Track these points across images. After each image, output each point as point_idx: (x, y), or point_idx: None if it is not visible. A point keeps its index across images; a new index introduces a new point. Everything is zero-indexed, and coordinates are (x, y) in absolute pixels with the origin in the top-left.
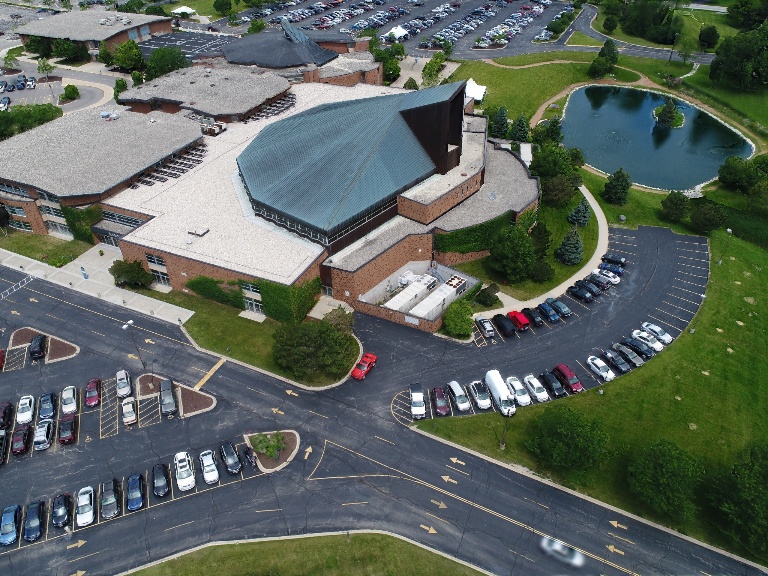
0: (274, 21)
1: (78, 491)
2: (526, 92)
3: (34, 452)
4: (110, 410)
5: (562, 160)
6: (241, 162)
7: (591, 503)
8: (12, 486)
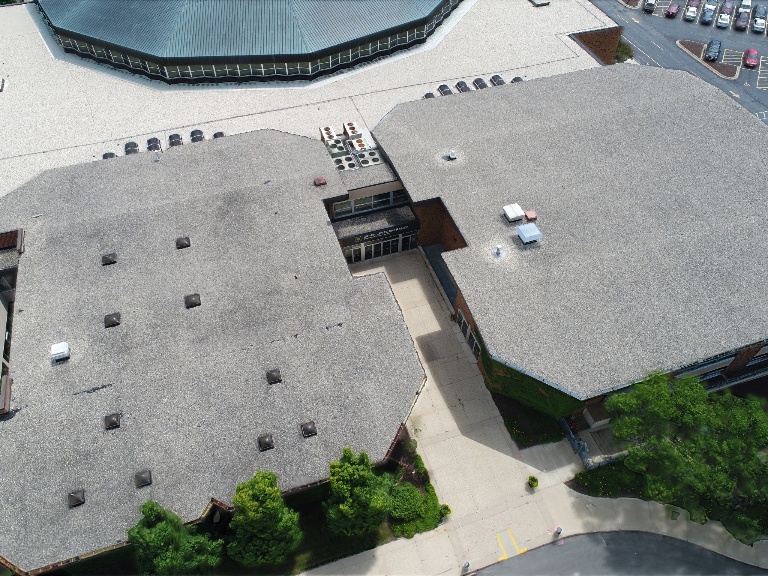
0: None
1: None
2: None
3: (718, 4)
4: (664, 2)
5: None
6: (431, 5)
7: None
8: None
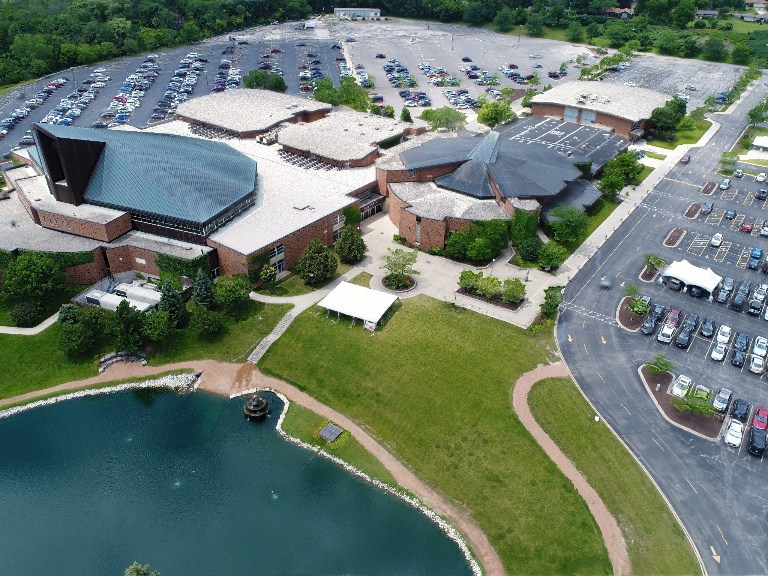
0: (759, 193)
1: None
2: (389, 395)
3: None
4: None
5: (8, 264)
6: None
7: None
8: None
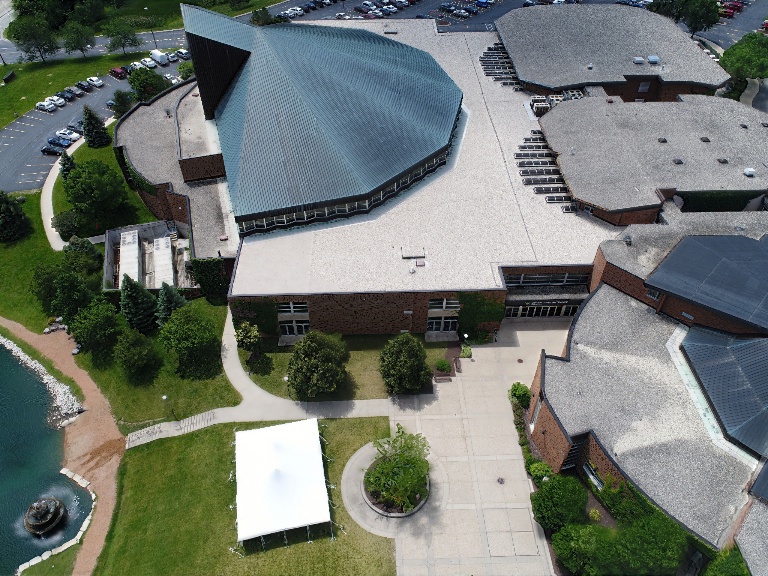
0: None
1: (333, 4)
2: None
3: None
4: None
5: (78, 164)
6: None
7: (116, 53)
8: (360, 0)
